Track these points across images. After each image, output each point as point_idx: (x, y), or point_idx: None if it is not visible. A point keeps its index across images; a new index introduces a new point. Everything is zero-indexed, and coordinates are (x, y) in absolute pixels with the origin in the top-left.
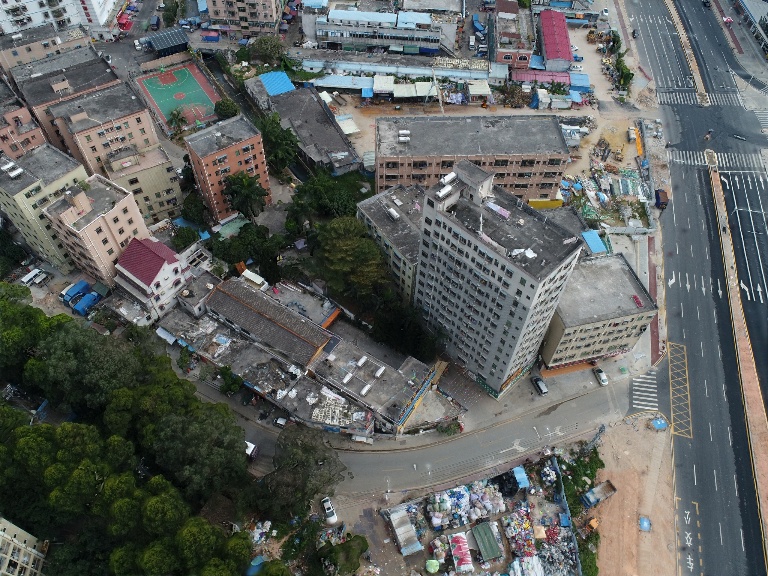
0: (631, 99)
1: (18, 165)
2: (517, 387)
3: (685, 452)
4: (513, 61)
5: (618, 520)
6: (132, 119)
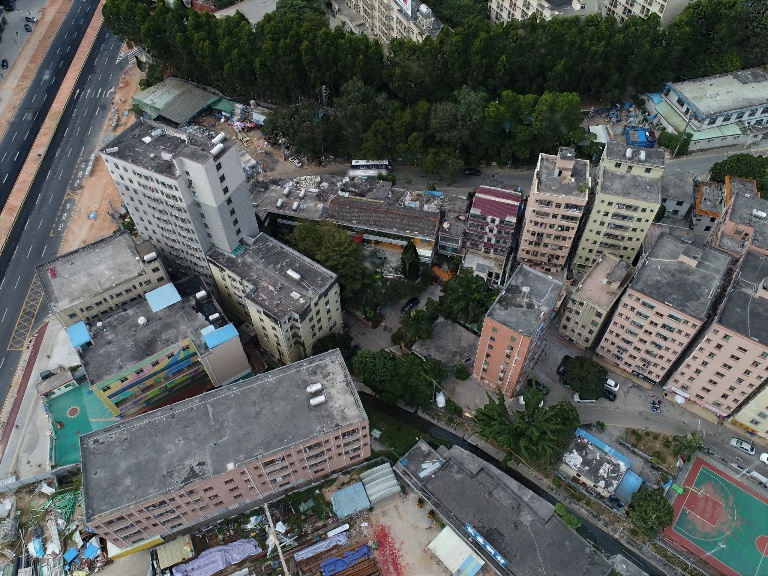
0: None
1: (641, 164)
2: None
3: None
4: None
5: None
6: None
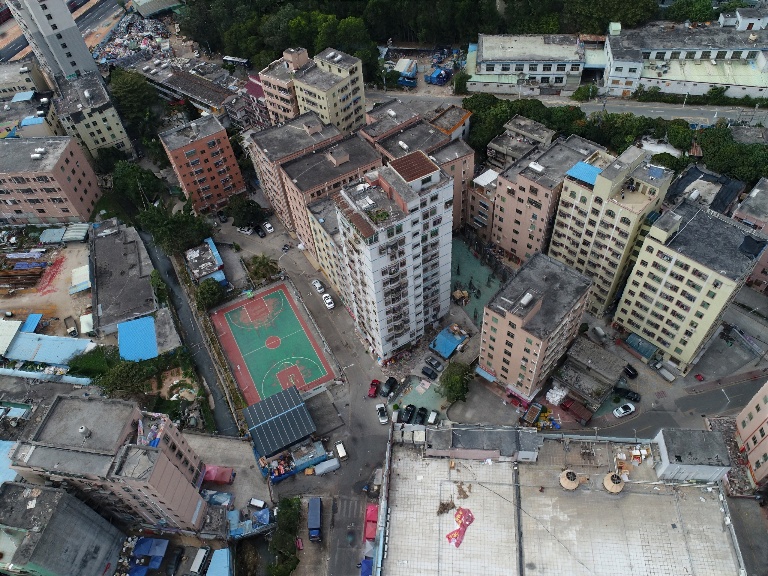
0: None
1: (333, 64)
2: None
3: None
4: None
5: None
6: None
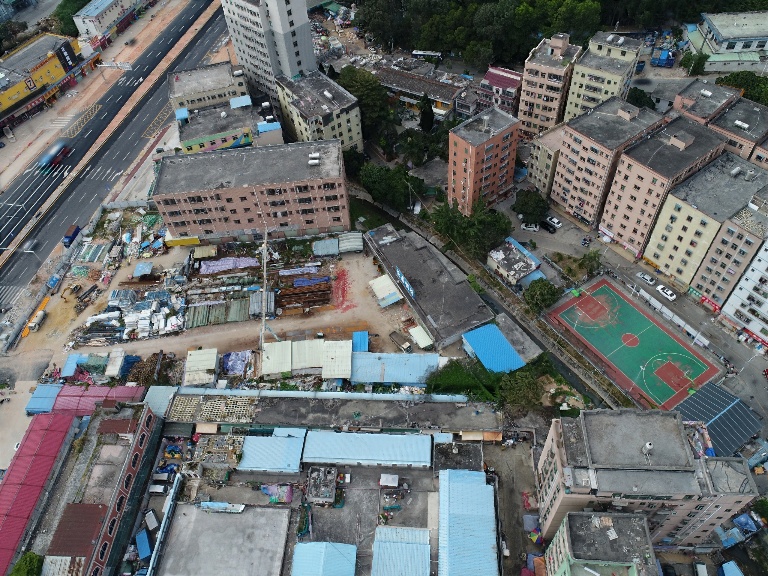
0: None
1: (617, 47)
2: None
3: None
4: None
5: None
6: None
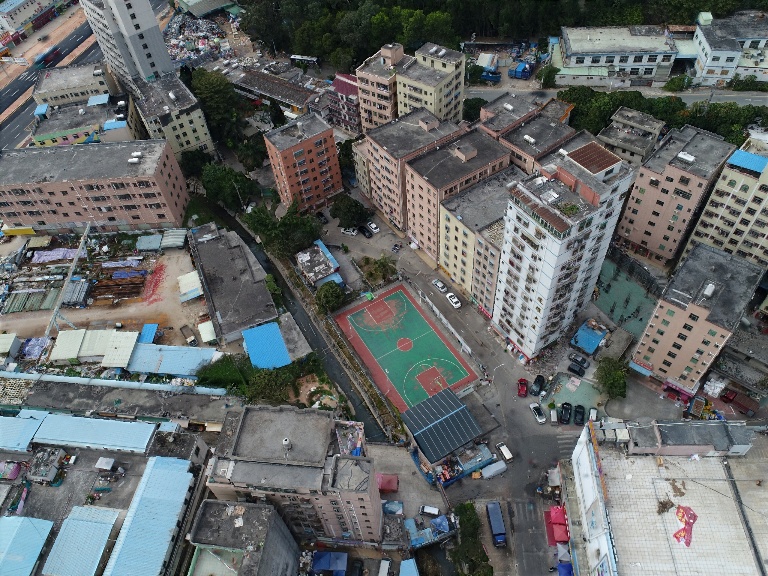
0: None
1: (438, 59)
2: None
3: None
4: None
5: None
6: None
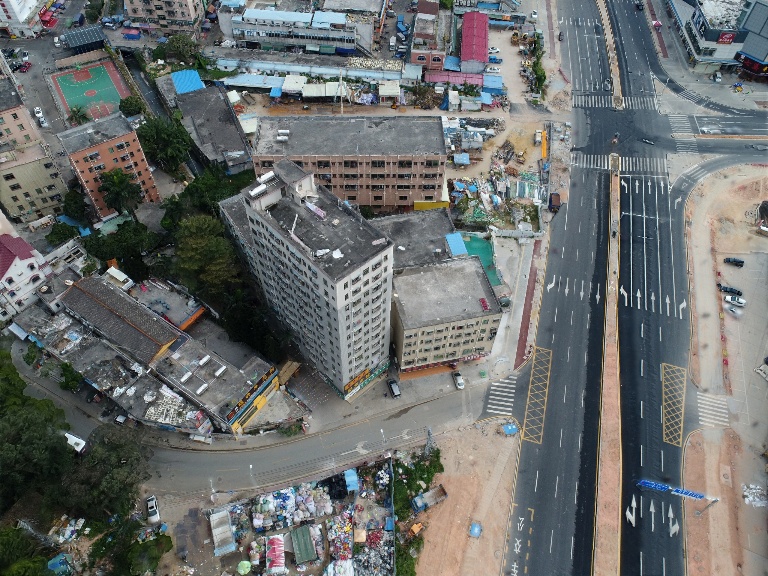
0: (545, 102)
1: None
2: (372, 389)
3: (531, 458)
4: (427, 62)
5: (446, 525)
6: (7, 115)
